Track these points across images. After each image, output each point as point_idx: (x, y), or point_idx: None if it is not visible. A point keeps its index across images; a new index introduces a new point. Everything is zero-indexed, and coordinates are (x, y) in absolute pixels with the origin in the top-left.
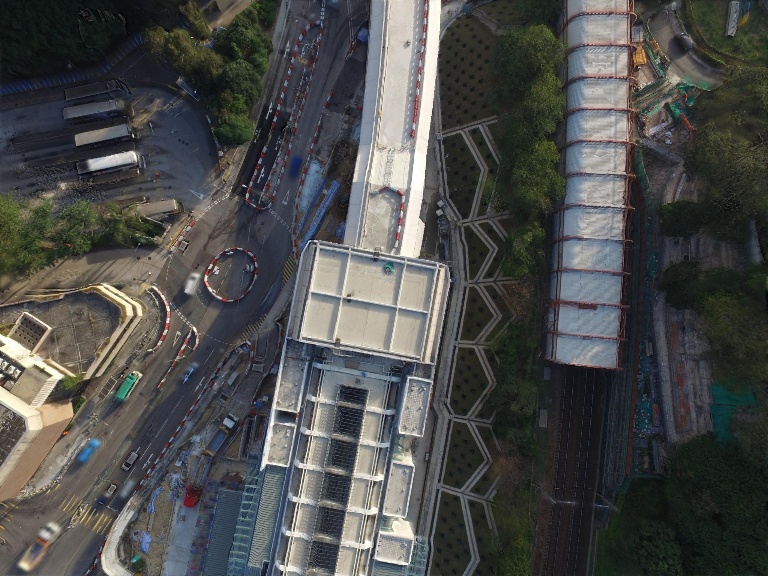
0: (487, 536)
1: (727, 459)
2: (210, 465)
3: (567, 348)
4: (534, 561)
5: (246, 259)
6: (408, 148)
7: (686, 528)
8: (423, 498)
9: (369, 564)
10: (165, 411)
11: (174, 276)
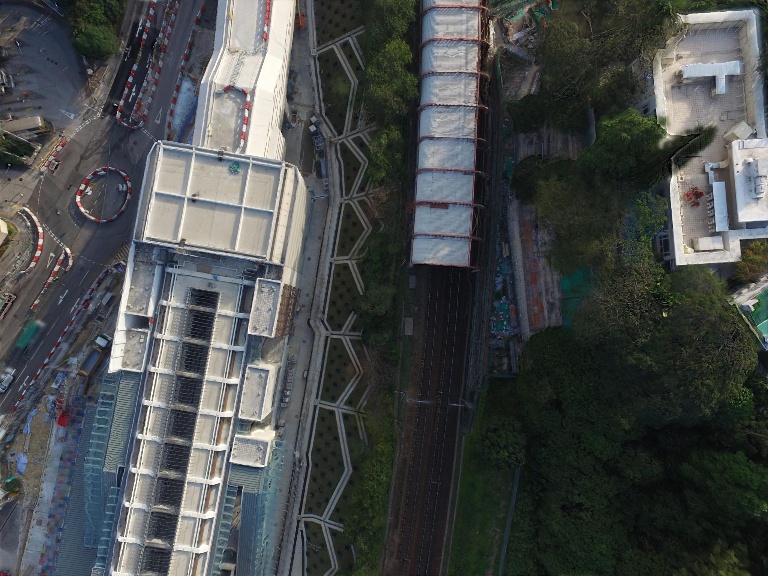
0: (358, 446)
1: (563, 345)
2: (86, 386)
3: (420, 248)
4: (400, 467)
5: (119, 179)
6: (261, 51)
7: (530, 419)
8: (301, 414)
9: (226, 467)
10: (40, 333)
11: (46, 197)
